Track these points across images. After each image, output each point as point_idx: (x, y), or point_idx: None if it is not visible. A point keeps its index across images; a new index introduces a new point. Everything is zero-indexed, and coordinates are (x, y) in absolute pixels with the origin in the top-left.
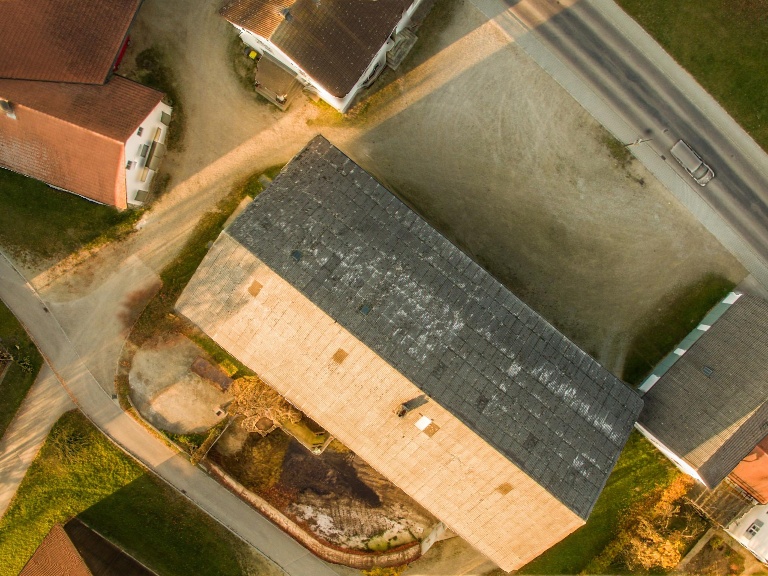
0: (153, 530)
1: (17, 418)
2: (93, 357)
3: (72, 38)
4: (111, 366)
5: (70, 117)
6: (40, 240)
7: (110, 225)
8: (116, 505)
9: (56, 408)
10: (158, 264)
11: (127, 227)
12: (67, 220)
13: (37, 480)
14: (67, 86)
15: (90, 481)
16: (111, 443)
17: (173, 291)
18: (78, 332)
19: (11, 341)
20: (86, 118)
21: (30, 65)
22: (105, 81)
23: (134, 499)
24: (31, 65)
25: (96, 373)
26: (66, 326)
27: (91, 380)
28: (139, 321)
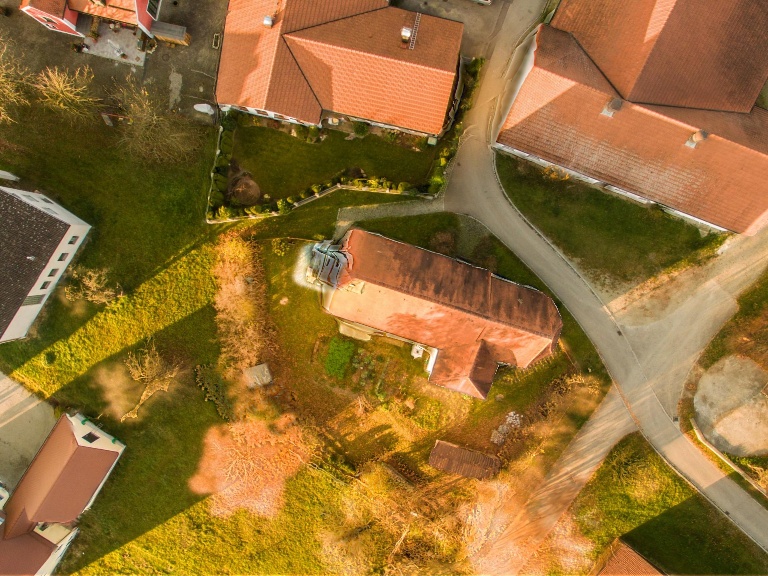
0: (693, 551)
1: (576, 440)
2: (660, 380)
3: (735, 67)
4: (676, 389)
5: (756, 147)
6: (621, 264)
7: (692, 250)
8: (660, 526)
9: (618, 430)
10: (735, 289)
11: (709, 252)
12: (650, 244)
13: (588, 502)
14: (727, 115)
15: (639, 503)
16: (666, 465)
17: (754, 316)
18: (649, 355)
19: (584, 364)
20: (767, 148)
21: (700, 94)
22: (750, 110)
23: (679, 520)
24: (701, 94)
25: (661, 396)
26: (638, 349)
27: (655, 403)
28: (710, 345)
